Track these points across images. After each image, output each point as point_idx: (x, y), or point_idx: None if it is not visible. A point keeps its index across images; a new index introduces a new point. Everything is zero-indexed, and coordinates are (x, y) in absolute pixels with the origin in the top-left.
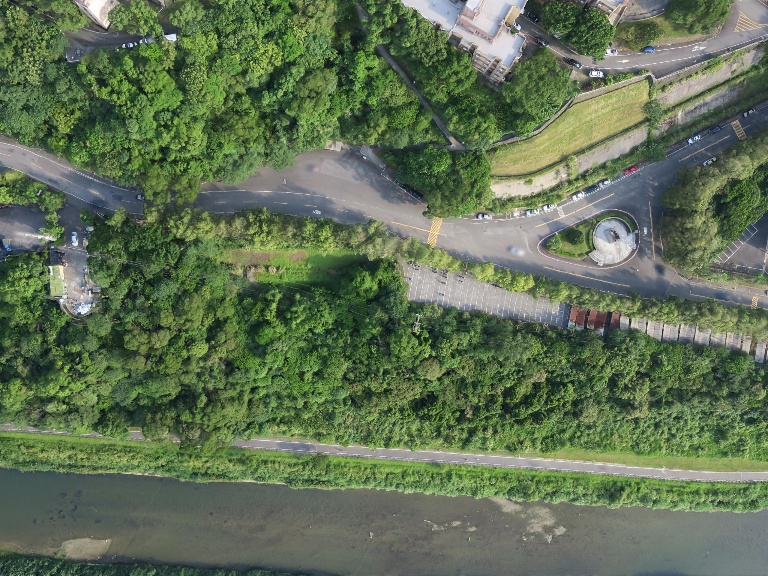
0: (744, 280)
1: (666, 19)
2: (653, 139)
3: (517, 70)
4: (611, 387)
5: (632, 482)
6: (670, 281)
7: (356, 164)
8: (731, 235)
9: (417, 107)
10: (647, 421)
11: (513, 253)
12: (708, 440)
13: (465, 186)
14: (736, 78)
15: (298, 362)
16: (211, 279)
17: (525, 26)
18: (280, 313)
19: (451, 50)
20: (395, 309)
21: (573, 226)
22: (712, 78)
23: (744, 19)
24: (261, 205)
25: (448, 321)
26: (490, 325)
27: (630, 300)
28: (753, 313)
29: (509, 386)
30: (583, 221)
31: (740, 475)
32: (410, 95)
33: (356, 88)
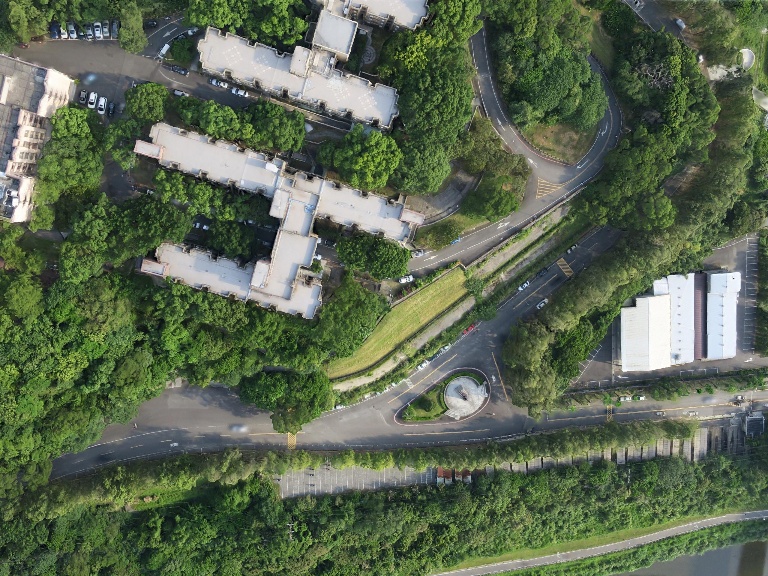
0: (595, 397)
1: (462, 214)
2: (482, 300)
3: (321, 315)
4: (491, 514)
5: (532, 572)
6: (526, 415)
7: (201, 391)
8: (571, 374)
9: (239, 350)
10: (534, 522)
11: (372, 431)
12: (593, 522)
13: (303, 411)
14: (549, 232)
15: (195, 571)
16: (88, 534)
17: (325, 253)
18: (167, 532)
19: (252, 313)
20: (269, 517)
21: (423, 393)
22: (525, 240)
23: (543, 184)
24: (118, 454)
25: (323, 510)
26: (363, 502)
27: (486, 456)
28: (605, 434)
29: (396, 540)
30: (432, 386)
31: (628, 543)
32: (228, 344)
33: (172, 356)
